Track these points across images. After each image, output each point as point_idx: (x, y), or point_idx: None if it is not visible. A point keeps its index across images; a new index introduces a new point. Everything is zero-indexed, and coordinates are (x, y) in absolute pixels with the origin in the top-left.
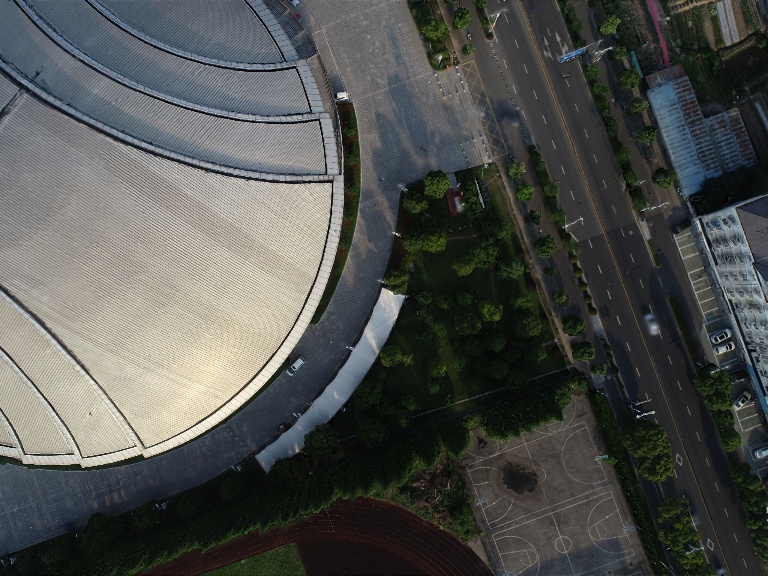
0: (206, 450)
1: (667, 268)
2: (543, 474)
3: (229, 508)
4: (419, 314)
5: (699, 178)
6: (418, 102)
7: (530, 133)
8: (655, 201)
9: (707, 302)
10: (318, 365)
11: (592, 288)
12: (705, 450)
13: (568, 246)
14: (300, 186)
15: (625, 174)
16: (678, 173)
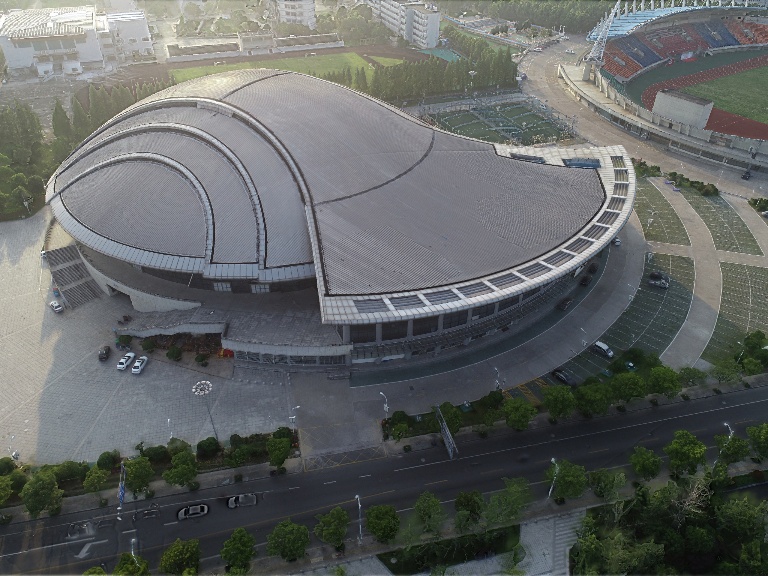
0: None
1: None
2: None
3: None
4: None
5: None
6: None
7: None
8: None
9: None
10: None
11: None
12: None
13: None
14: None
15: None
16: None
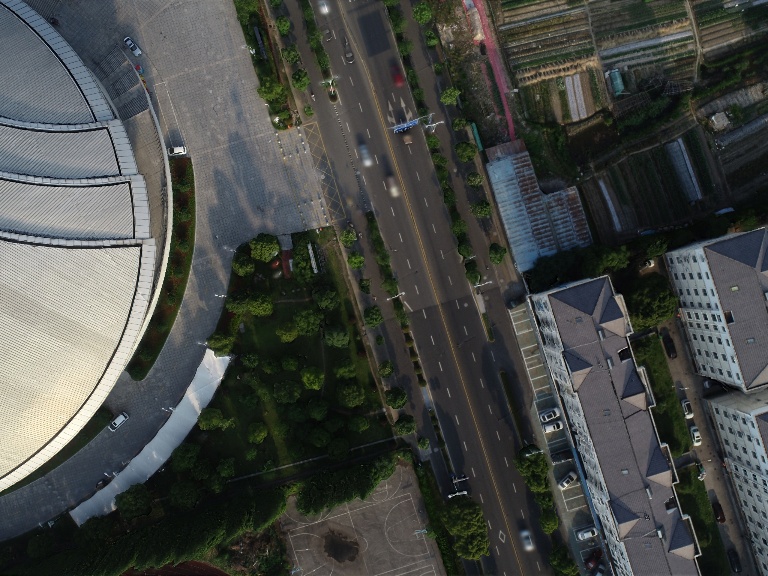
0: (23, 502)
1: (500, 343)
2: (365, 544)
3: (34, 566)
4: (244, 377)
5: (533, 255)
6: (257, 161)
7: (369, 199)
8: (492, 274)
9: (539, 379)
10: (142, 422)
11: (424, 359)
12: (528, 528)
13: (400, 315)
14: (99, 251)
15: (459, 247)
16: (513, 249)
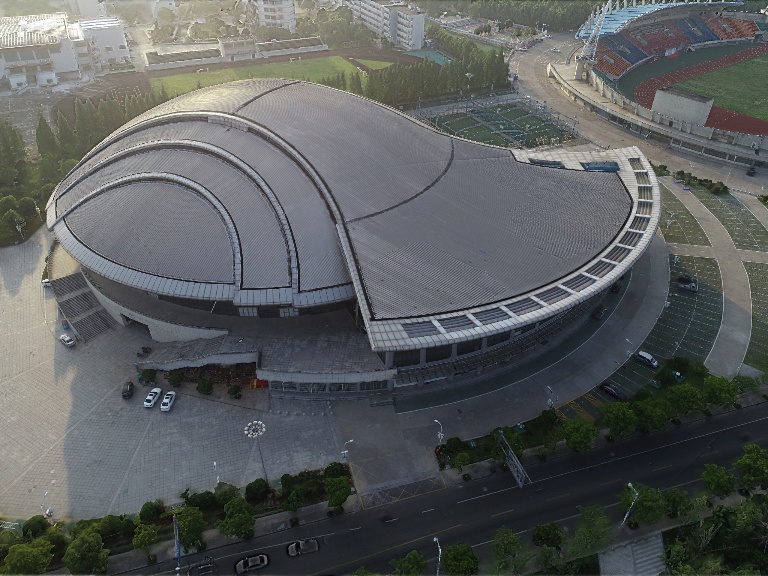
0: None
1: None
2: None
3: None
4: None
5: None
6: None
7: None
8: None
9: None
10: None
11: None
12: None
13: None
14: None
15: None
16: None
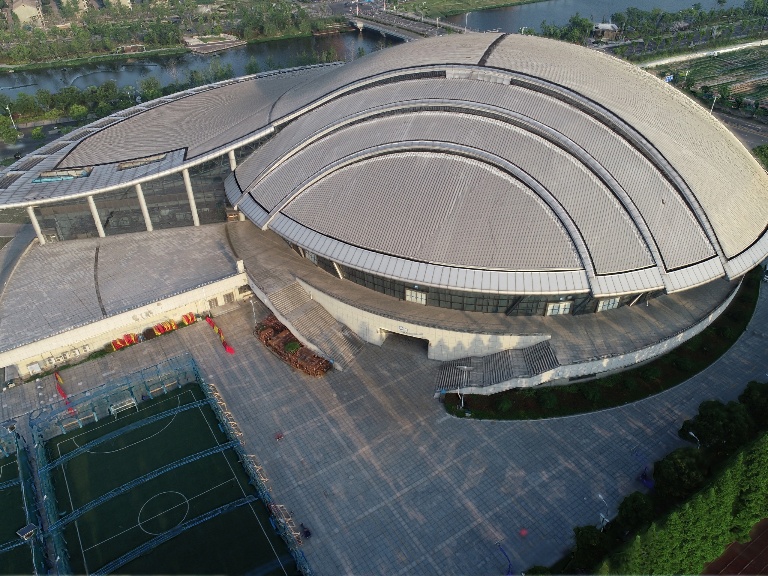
0: (749, 357)
1: None
2: None
3: None
4: None
5: None
6: None
7: None
8: None
9: None
10: None
11: None
12: None
13: None
14: None
15: None
16: None
